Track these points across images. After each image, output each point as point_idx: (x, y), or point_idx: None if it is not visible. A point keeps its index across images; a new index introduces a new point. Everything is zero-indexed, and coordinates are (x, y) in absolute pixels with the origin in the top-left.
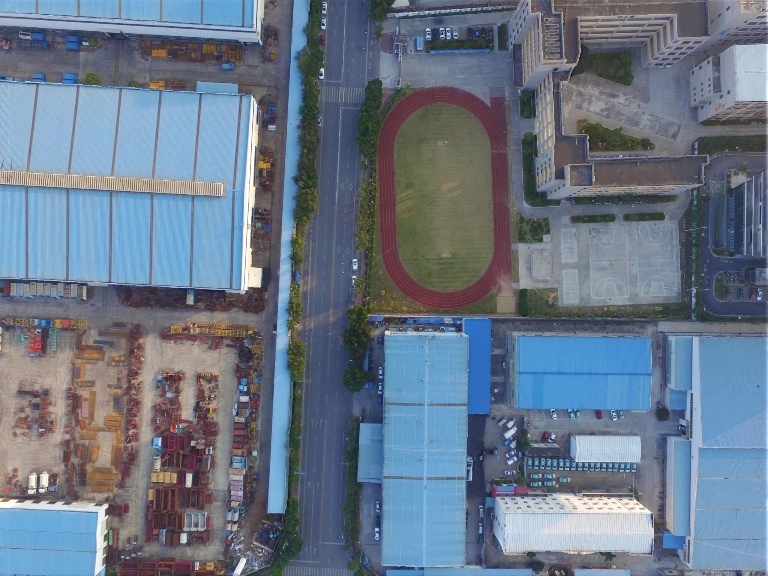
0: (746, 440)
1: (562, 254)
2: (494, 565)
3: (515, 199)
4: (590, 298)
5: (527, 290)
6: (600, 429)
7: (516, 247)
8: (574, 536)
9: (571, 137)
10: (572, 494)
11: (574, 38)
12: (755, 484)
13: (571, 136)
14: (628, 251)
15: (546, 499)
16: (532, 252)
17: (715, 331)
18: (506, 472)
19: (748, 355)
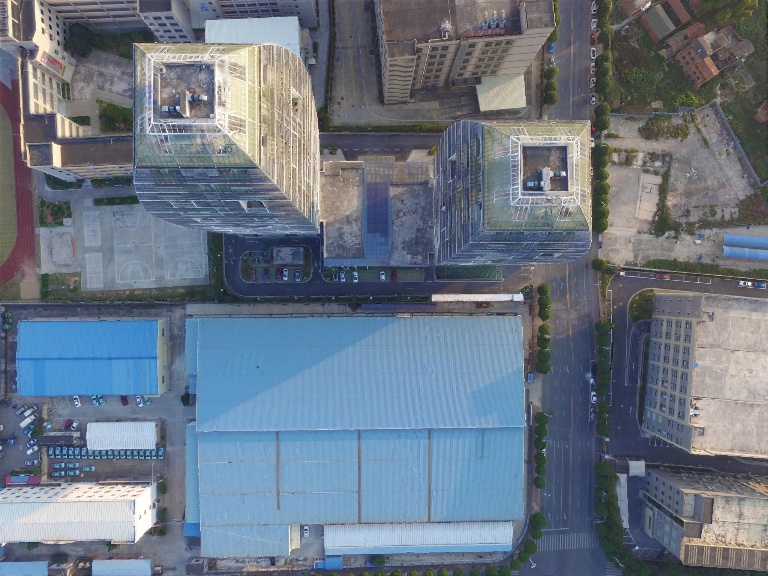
0: (242, 422)
1: (85, 238)
2: (15, 558)
3: (37, 182)
4: (114, 282)
5: (48, 275)
6: (127, 416)
7: (38, 231)
8: (51, 525)
9: (41, 116)
10: (94, 483)
11: (33, 15)
12: (260, 468)
13: (40, 115)
14: (153, 233)
15: (54, 489)
16: (53, 236)
17: (244, 313)
18: (26, 462)
19: (249, 336)
